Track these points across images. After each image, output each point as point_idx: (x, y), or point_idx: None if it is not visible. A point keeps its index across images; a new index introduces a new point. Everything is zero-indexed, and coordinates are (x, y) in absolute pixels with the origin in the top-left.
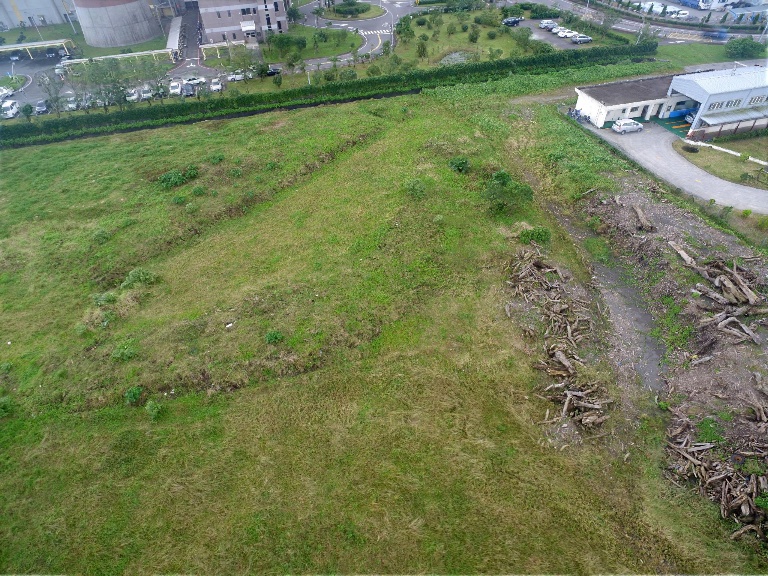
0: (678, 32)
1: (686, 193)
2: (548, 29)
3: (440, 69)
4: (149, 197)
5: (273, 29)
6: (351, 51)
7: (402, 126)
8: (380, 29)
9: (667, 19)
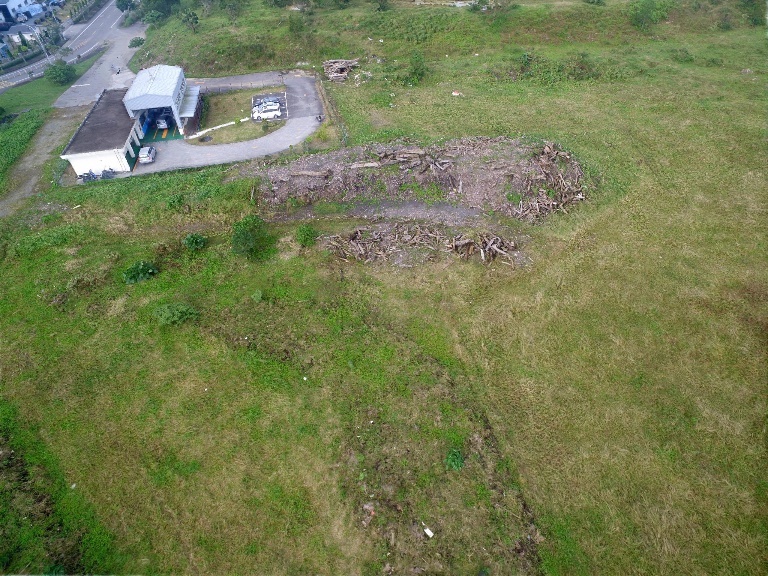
0: None
1: None
2: None
3: None
4: None
5: None
6: None
7: None
8: None
9: None
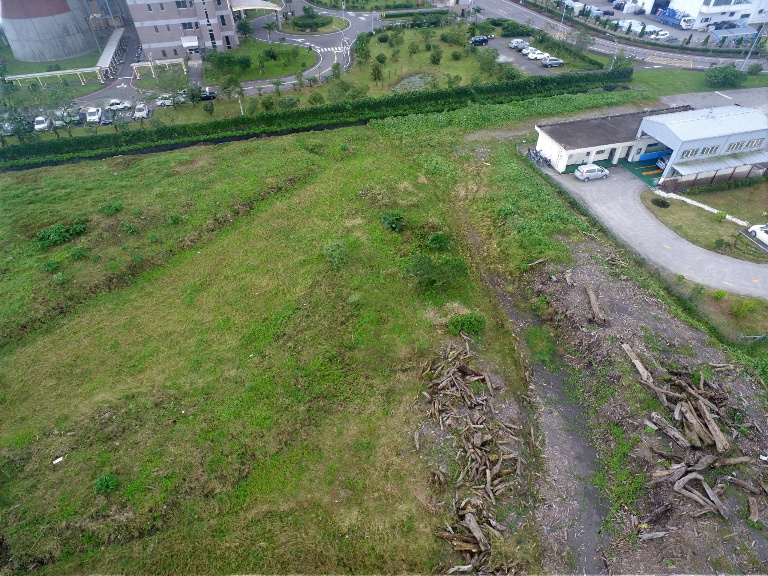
0: (657, 55)
1: (652, 263)
2: (518, 49)
3: (391, 97)
4: (20, 260)
5: (218, 45)
6: None
7: (339, 167)
8: (338, 46)
9: (646, 40)
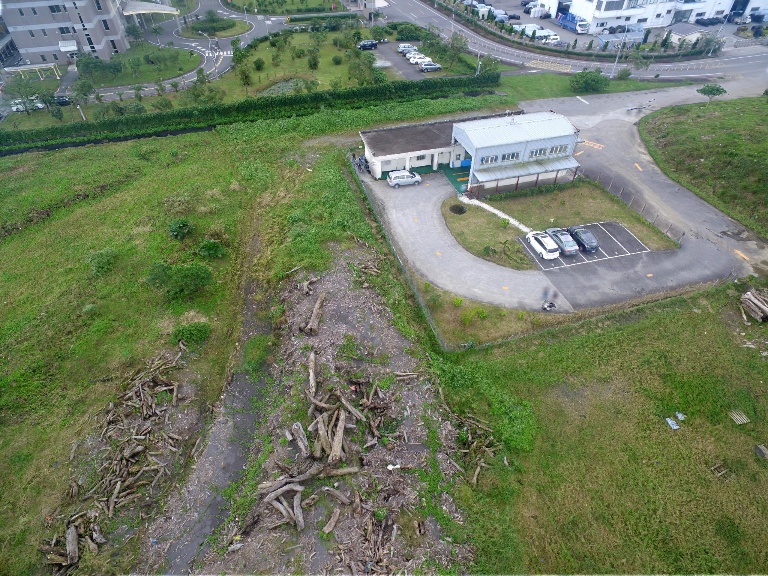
0: (540, 59)
1: (413, 270)
2: (403, 54)
3: (240, 103)
4: None
5: (97, 50)
6: (154, 80)
7: (159, 173)
8: (229, 50)
9: (536, 44)
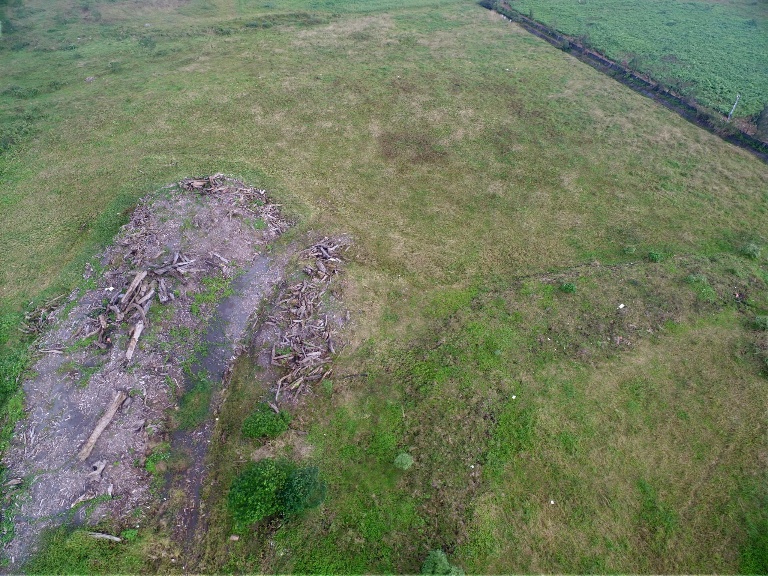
0: None
1: None
2: None
3: None
4: None
5: None
6: None
7: None
8: None
9: None
